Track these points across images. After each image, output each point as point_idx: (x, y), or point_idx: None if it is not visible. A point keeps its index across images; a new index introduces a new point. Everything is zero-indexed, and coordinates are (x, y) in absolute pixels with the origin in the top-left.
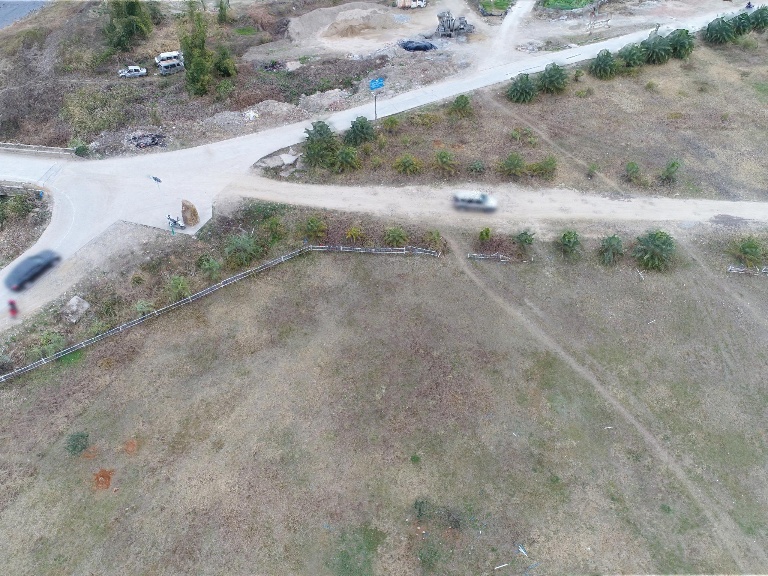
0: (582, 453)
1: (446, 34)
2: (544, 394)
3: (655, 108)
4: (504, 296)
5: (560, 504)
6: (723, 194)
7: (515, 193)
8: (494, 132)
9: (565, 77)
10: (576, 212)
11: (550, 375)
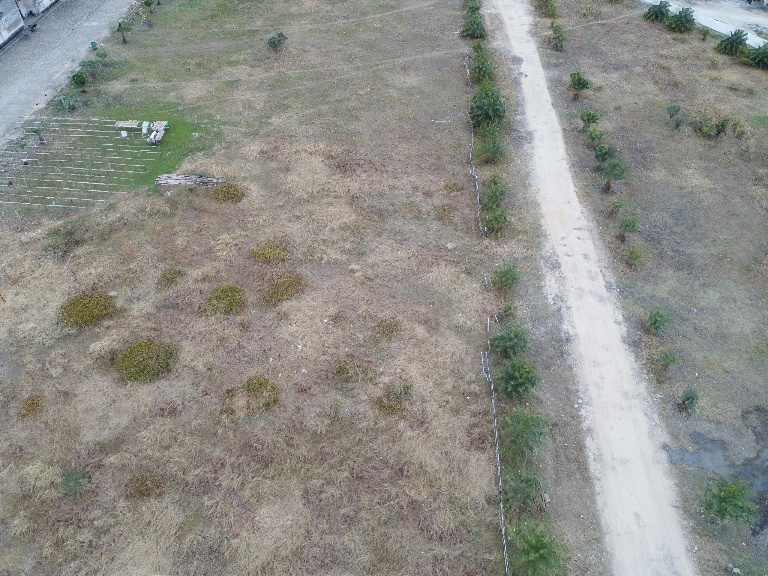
0: (347, 8)
1: (750, 0)
2: (376, 5)
3: (675, 63)
4: (435, 3)
5: (326, 3)
6: (550, 65)
7: (523, 8)
8: (594, 8)
9: (683, 21)
10: (510, 21)
11: (386, 7)
